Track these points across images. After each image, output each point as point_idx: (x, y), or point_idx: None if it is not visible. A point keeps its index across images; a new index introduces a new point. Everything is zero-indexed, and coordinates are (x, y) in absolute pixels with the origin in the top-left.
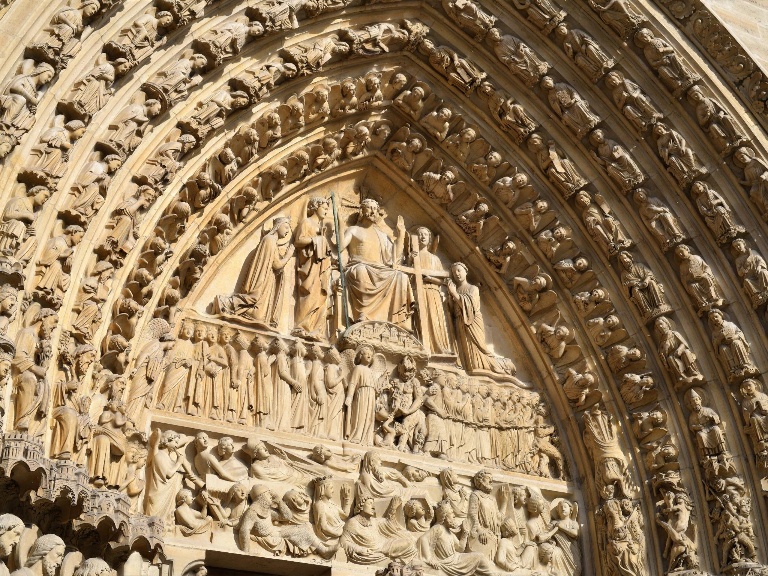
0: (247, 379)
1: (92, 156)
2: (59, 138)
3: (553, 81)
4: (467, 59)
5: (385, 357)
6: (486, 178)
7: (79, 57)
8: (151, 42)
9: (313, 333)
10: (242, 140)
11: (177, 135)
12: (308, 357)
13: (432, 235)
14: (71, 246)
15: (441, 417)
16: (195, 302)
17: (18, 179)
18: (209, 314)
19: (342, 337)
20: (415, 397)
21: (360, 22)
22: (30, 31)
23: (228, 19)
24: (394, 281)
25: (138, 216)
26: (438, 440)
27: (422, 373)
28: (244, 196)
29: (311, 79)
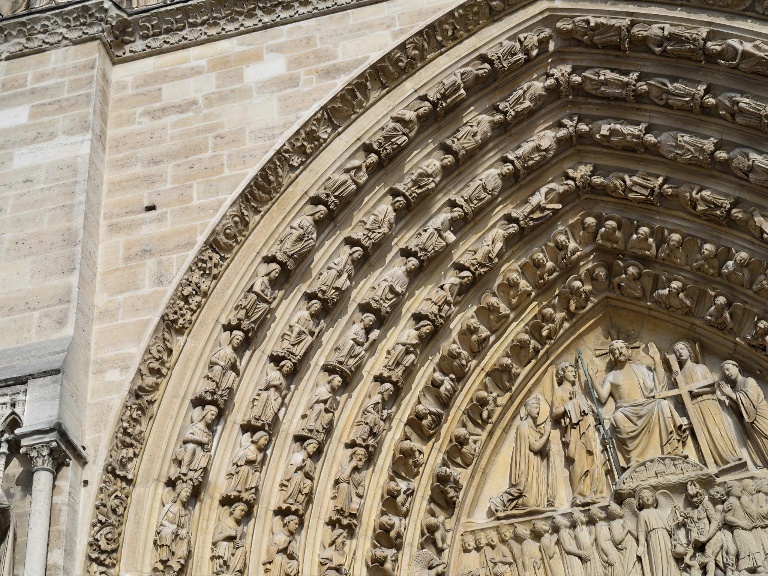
0: (534, 568)
1: (293, 449)
2: (244, 456)
3: (727, 152)
4: (638, 174)
5: (668, 491)
6: (710, 272)
7: (248, 379)
8: (311, 331)
9: (587, 498)
10: (447, 359)
11: (377, 388)
12: (591, 522)
13: (693, 345)
14: (292, 535)
15: (746, 530)
16: (472, 513)
17: (222, 504)
18: (487, 519)
19: (615, 491)
20: (710, 520)
21: (522, 197)
22: (190, 386)
23: (385, 269)
24: (656, 412)
25: (358, 476)
26: (749, 555)
27: (712, 492)
28: (475, 403)
29: (499, 270)
